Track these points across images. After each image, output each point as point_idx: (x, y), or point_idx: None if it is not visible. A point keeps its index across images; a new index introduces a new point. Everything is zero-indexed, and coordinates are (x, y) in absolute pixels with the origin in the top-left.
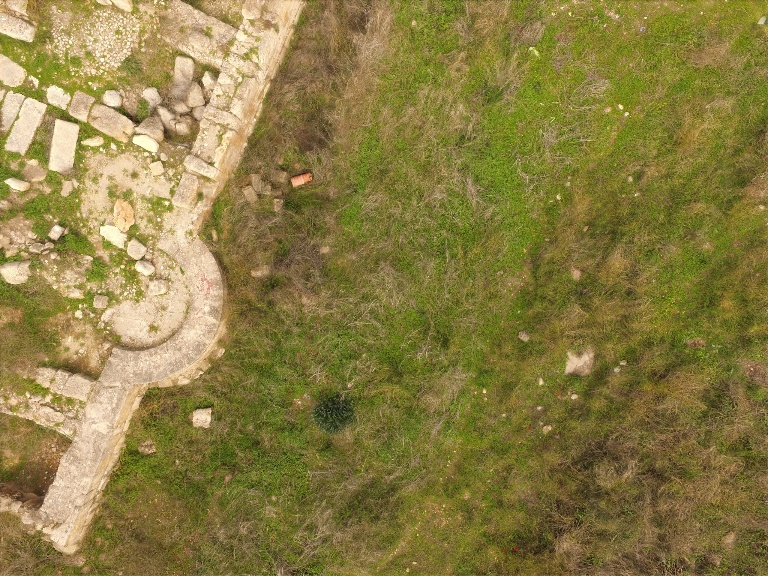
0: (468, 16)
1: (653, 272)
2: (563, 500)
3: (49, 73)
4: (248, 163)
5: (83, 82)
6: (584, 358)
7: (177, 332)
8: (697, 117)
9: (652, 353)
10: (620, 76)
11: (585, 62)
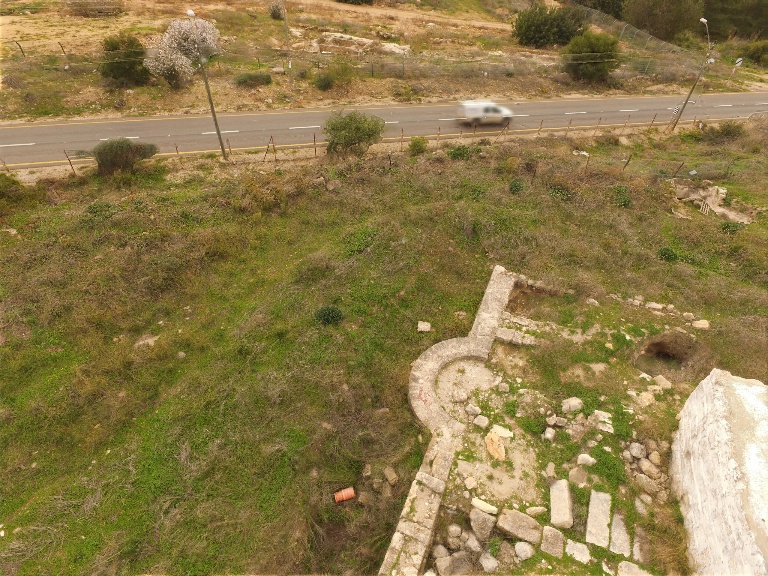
0: None
1: (59, 394)
2: None
3: None
4: (393, 503)
5: (557, 568)
6: None
7: (442, 367)
8: None
9: (92, 340)
10: None
11: None
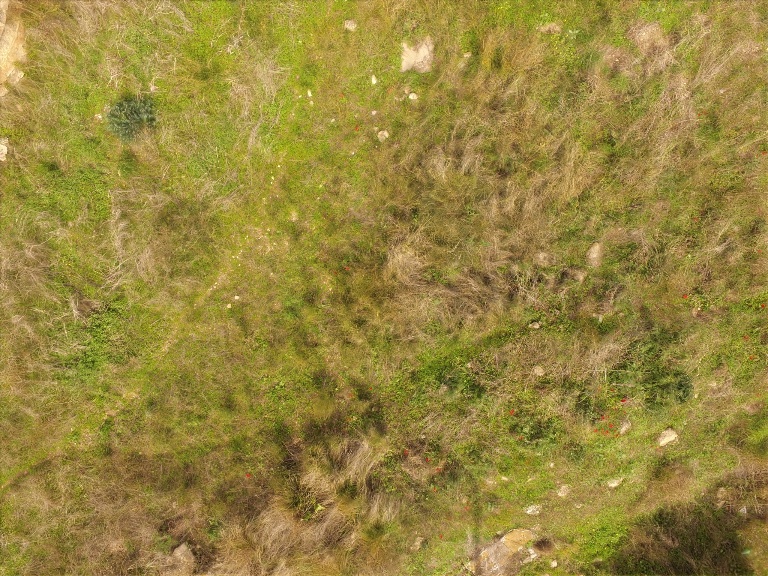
0: None
1: None
2: (401, 212)
3: None
4: None
5: None
6: (423, 51)
7: None
8: None
9: (496, 34)
10: None
11: None
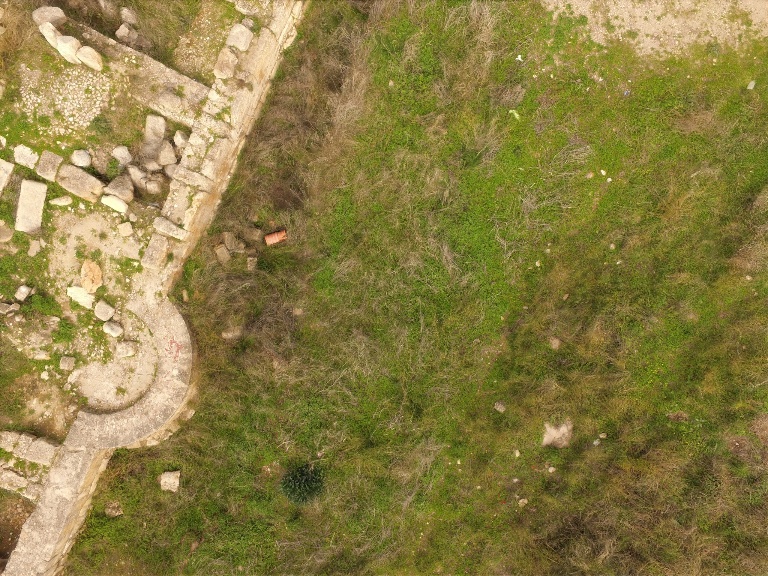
0: (445, 79)
1: (635, 343)
2: None
3: (17, 132)
4: (221, 222)
5: (51, 141)
6: (562, 430)
7: (144, 395)
8: (682, 184)
9: (632, 428)
10: (603, 141)
11: (566, 126)
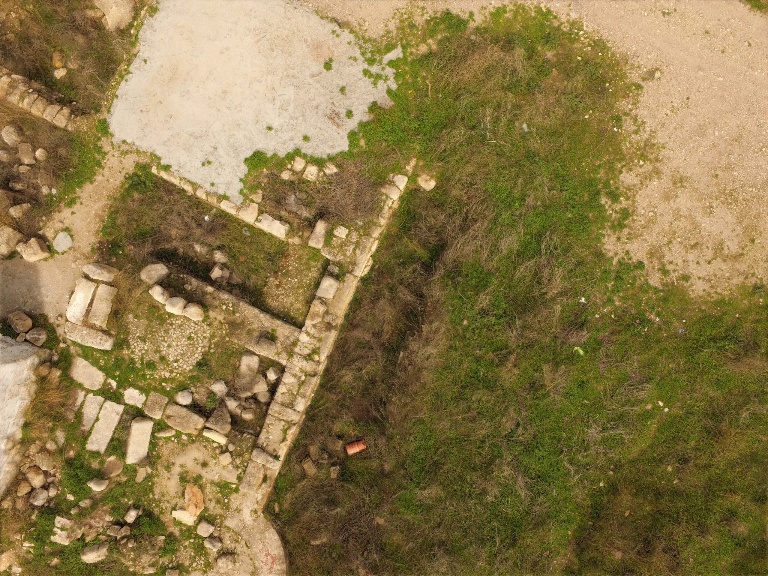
0: (518, 327)
1: (691, 553)
2: None
3: (126, 376)
4: (307, 439)
5: (157, 383)
6: None
7: None
8: (733, 412)
9: None
10: (660, 376)
11: (627, 363)
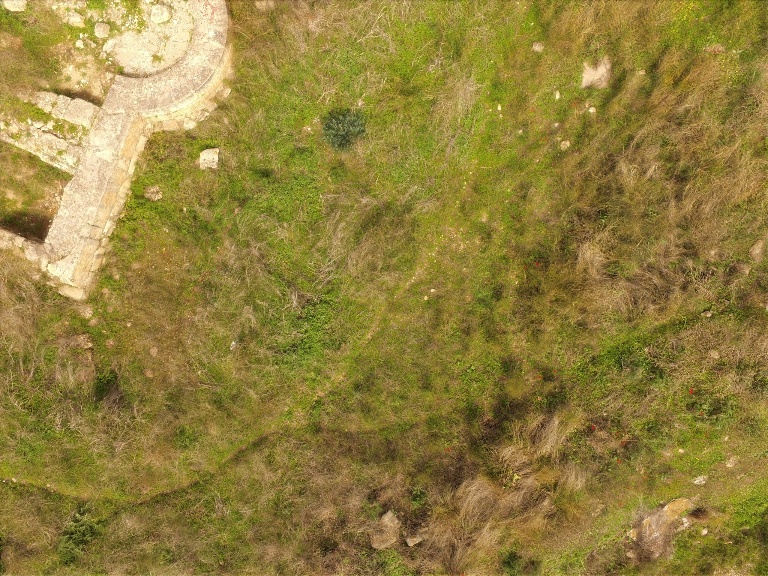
0: None
1: None
2: (584, 213)
3: None
4: None
5: None
6: (601, 70)
7: (181, 58)
8: None
9: (671, 55)
10: None
11: None
